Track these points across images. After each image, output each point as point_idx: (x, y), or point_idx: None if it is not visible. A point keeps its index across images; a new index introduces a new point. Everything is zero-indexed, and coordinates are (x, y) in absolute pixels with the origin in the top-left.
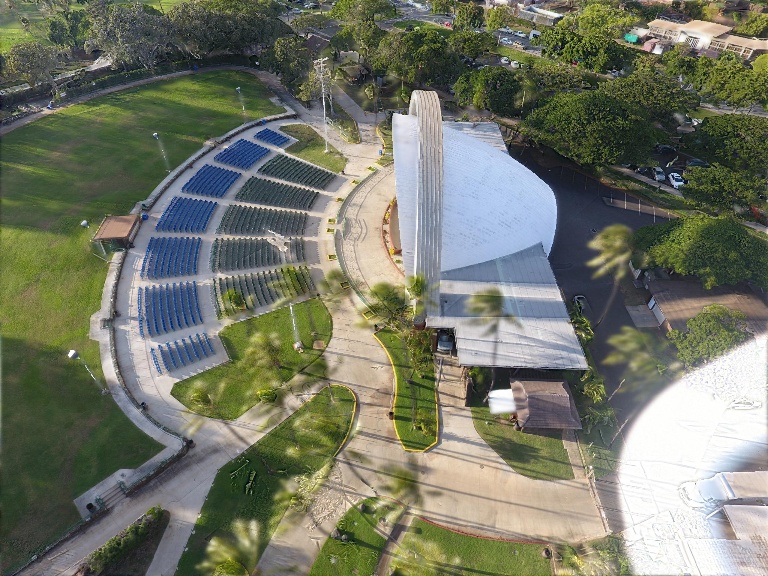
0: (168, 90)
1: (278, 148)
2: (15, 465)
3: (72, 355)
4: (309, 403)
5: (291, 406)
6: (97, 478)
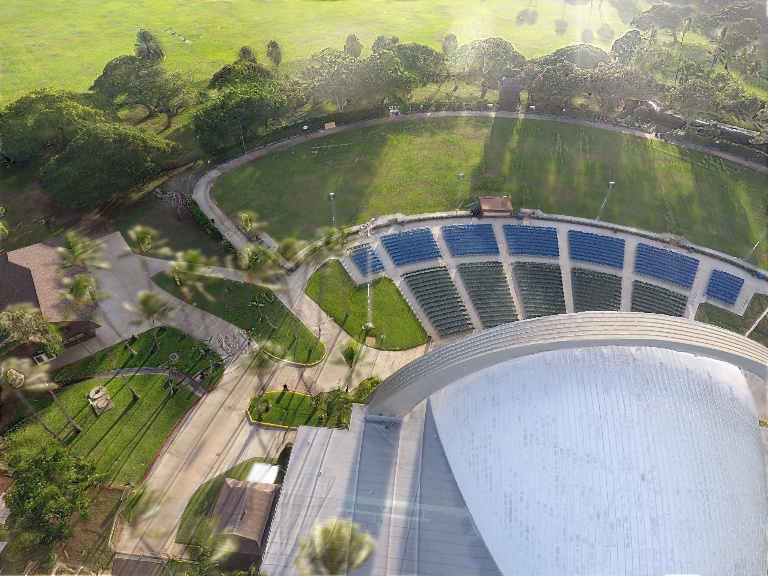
0: (763, 188)
1: (705, 296)
2: (291, 210)
3: (330, 194)
4: (311, 334)
5: (310, 323)
6: (275, 238)
